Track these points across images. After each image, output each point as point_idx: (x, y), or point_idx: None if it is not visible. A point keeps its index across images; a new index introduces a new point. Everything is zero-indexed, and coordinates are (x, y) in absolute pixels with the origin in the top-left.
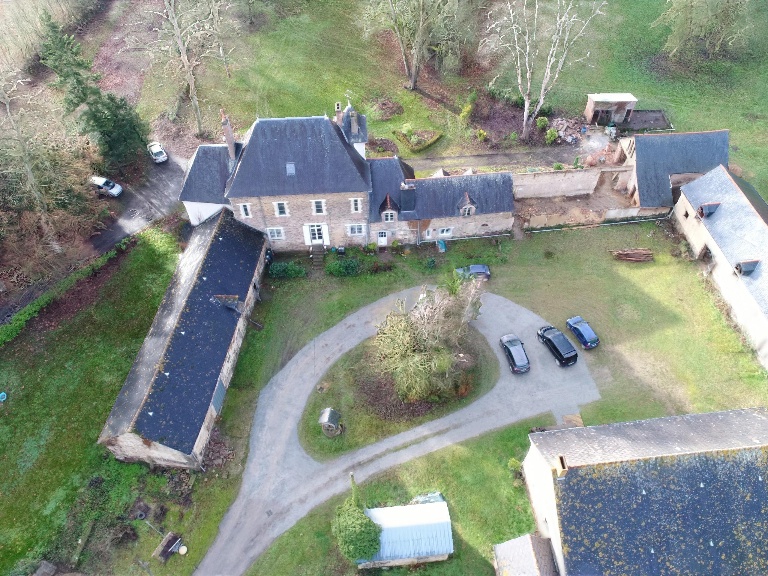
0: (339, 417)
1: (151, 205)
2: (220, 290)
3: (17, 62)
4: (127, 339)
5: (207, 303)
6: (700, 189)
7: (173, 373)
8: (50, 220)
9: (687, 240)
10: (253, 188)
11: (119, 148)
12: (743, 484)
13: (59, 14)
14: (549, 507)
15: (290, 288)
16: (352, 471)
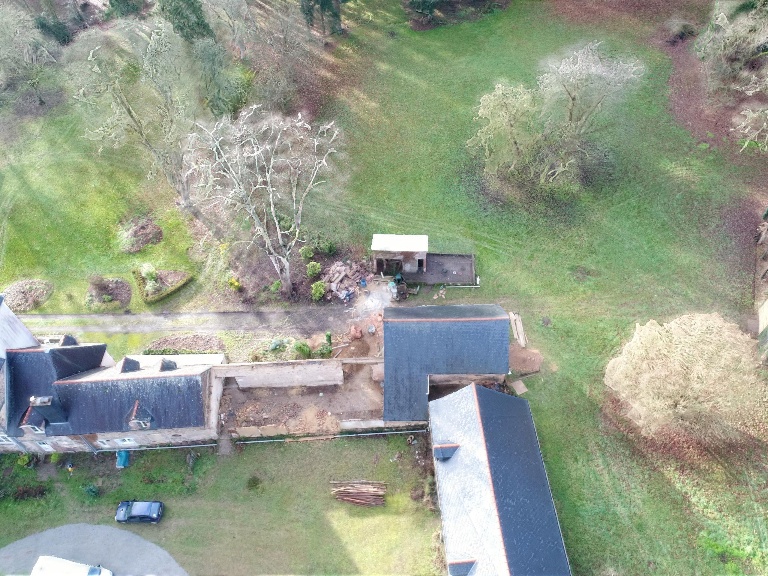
0: None
1: None
2: None
3: None
4: None
5: None
6: (446, 413)
7: None
8: None
9: (434, 476)
10: None
11: None
12: None
13: None
14: None
15: None
16: None
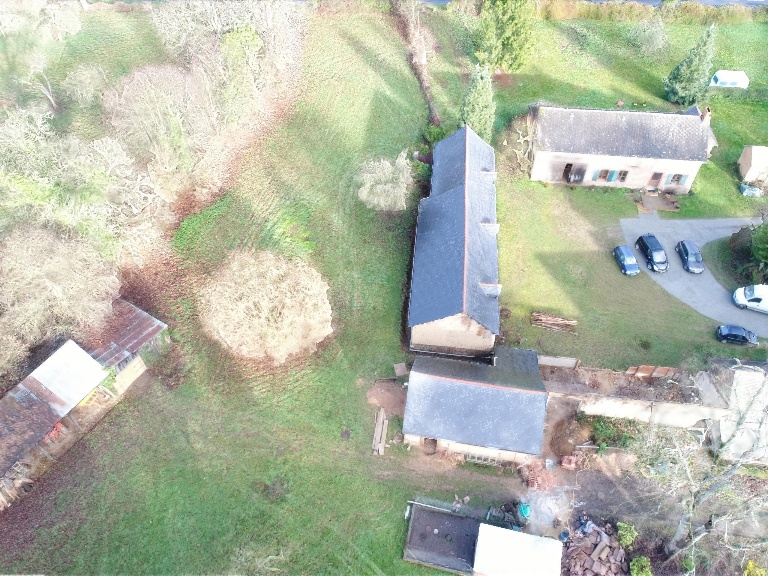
0: None
1: None
2: None
3: None
4: None
5: None
6: (487, 313)
7: None
8: None
9: None
10: None
11: None
12: None
13: None
14: None
15: None
16: None
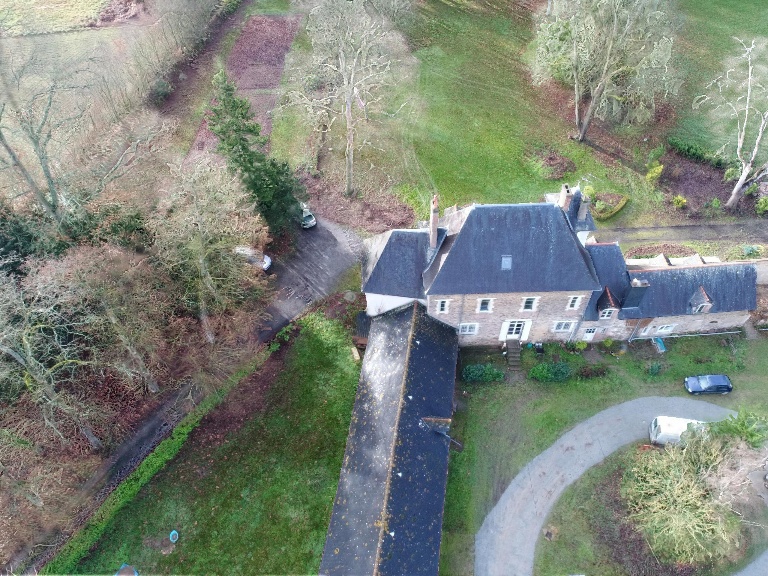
0: None
1: (307, 282)
2: (426, 410)
3: (132, 102)
4: (308, 460)
5: (416, 430)
6: None
7: (397, 531)
8: (227, 323)
9: None
10: (459, 284)
11: (279, 220)
12: None
13: (173, 47)
14: None
15: (486, 394)
16: None
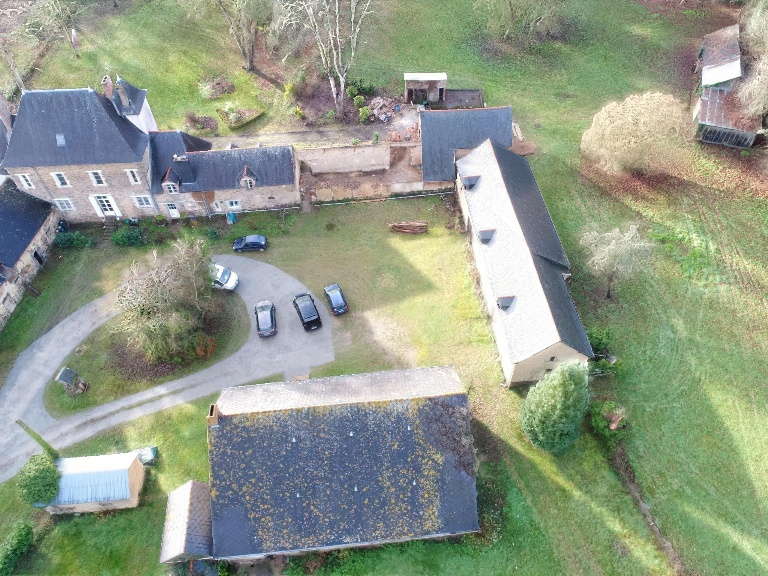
0: (75, 376)
1: None
2: None
3: None
4: None
5: None
6: (470, 163)
7: None
8: None
9: (462, 213)
10: (26, 158)
11: None
12: (392, 433)
13: None
14: None
15: (77, 257)
16: (83, 427)
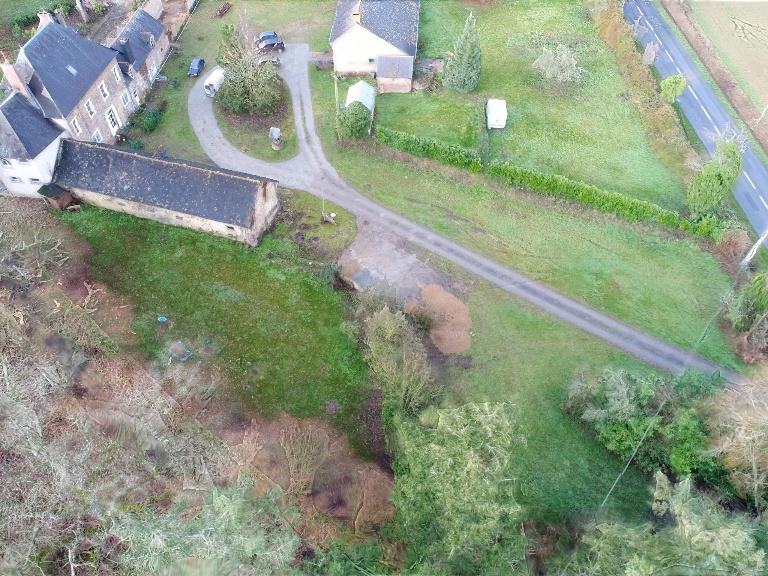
0: None
1: None
2: None
3: None
4: (144, 244)
5: None
6: None
7: None
8: None
9: None
10: (69, 100)
11: None
12: None
13: None
14: (368, 45)
15: None
16: (310, 141)
